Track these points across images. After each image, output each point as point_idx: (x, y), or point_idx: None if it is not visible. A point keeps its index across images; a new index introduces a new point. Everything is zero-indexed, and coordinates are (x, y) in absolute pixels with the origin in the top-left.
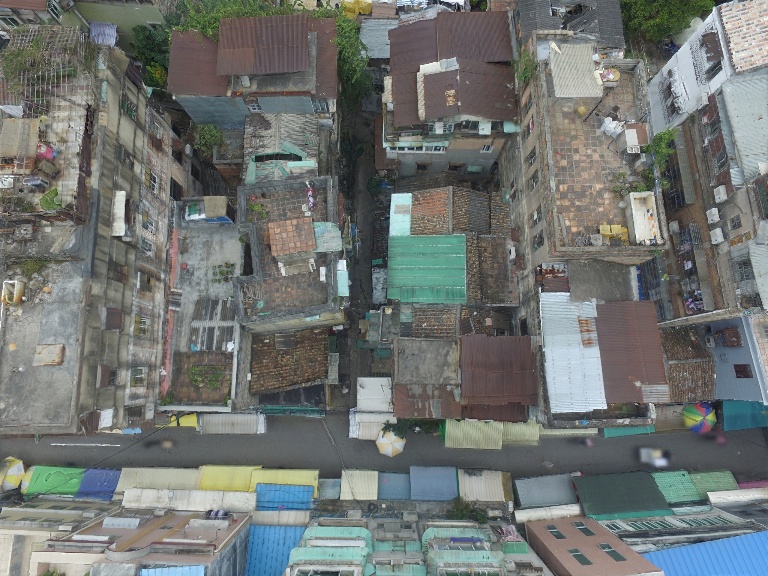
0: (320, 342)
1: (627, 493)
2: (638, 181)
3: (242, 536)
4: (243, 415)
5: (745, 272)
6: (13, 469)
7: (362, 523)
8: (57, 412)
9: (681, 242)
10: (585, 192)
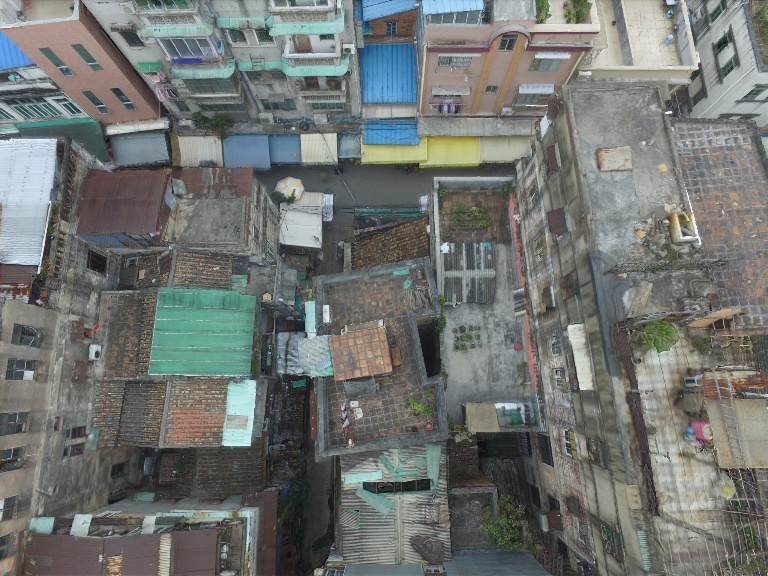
0: None
1: None
2: None
3: None
4: None
5: None
6: None
7: (301, 93)
8: (588, 103)
9: None
10: None
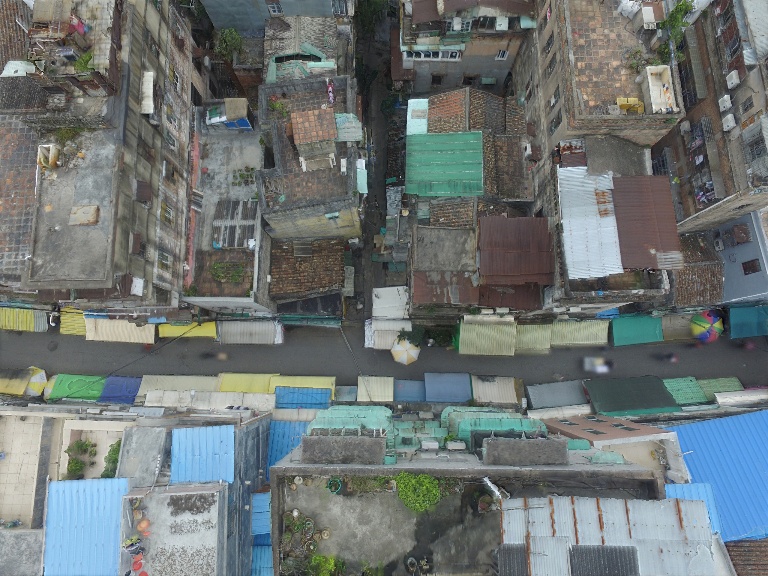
0: (337, 252)
1: (637, 394)
2: (654, 59)
3: (264, 425)
4: (261, 325)
5: (757, 151)
6: (36, 377)
7: None
8: (93, 268)
9: (693, 139)
10: (602, 69)
